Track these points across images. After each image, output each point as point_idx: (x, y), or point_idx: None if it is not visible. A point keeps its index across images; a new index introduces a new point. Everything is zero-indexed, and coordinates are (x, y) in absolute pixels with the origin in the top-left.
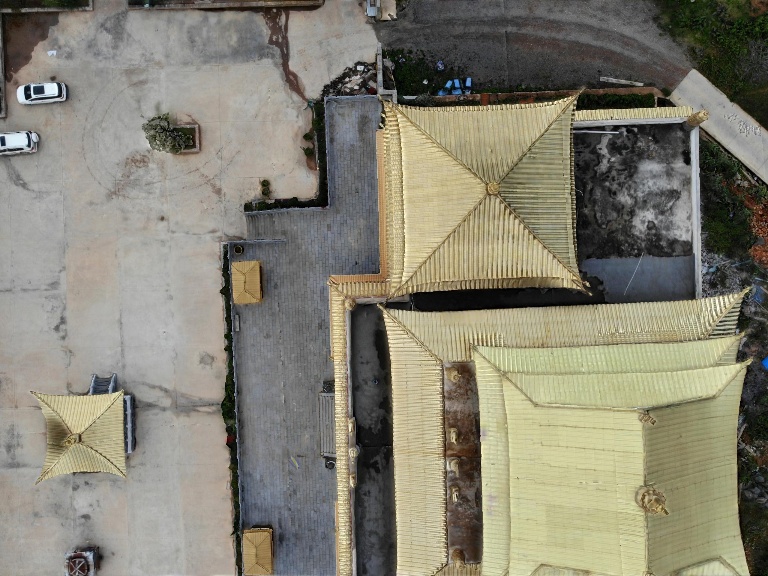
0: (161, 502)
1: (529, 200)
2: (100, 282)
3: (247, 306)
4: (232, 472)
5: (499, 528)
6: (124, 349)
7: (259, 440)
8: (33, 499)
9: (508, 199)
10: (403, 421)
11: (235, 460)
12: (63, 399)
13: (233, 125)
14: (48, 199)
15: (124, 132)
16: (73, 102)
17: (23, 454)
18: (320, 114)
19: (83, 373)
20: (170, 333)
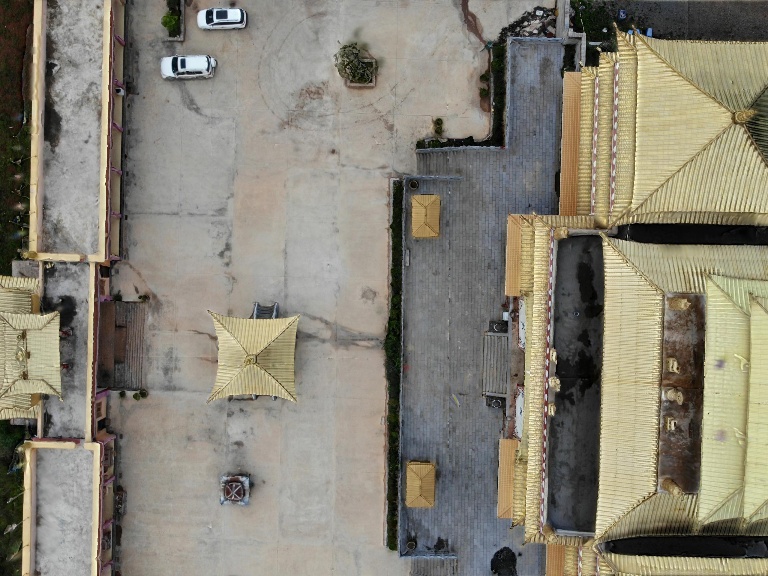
0: (315, 433)
1: (767, 133)
2: (267, 211)
3: (418, 242)
4: (389, 407)
5: (720, 457)
6: (287, 279)
7: (422, 376)
8: (187, 423)
9: (751, 130)
10: (615, 350)
11: (395, 394)
12: (237, 321)
13: (409, 62)
14: (220, 125)
15: (300, 63)
16: (251, 30)
17: (180, 377)
18: (500, 55)
19: (245, 300)
20: (334, 266)
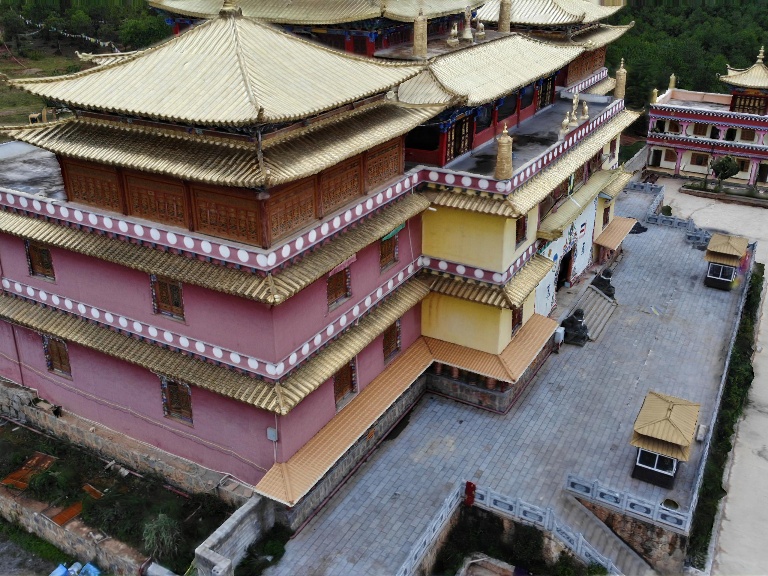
0: None
1: None
2: None
3: None
4: None
5: None
6: None
7: (701, 337)
8: None
9: None
10: (501, 82)
11: None
12: None
13: None
14: None
15: None
16: None
17: None
18: None
19: None
20: None
